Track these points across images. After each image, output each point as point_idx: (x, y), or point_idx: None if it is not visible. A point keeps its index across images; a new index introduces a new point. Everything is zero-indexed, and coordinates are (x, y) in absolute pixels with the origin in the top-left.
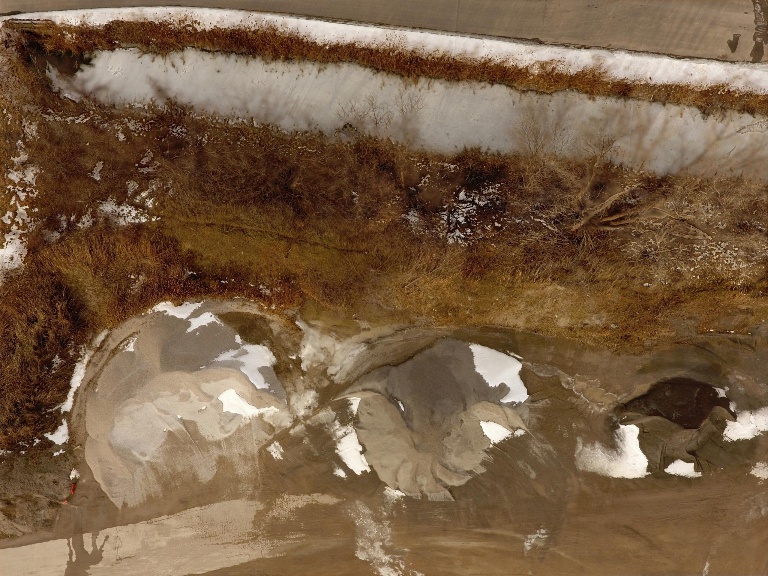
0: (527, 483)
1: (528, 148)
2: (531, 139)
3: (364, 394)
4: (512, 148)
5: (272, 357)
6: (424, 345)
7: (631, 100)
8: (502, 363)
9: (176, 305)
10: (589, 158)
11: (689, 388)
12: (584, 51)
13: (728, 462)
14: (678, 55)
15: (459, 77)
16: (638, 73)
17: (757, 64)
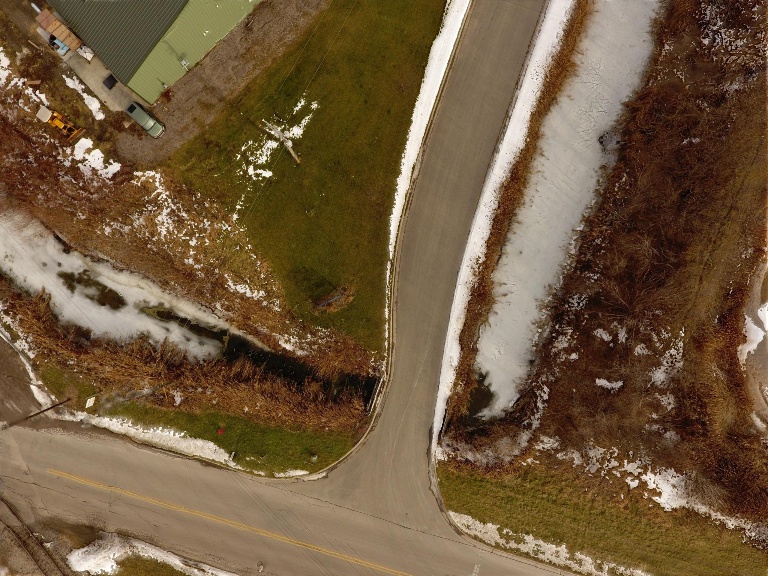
0: None
1: None
2: None
3: None
4: None
5: None
6: None
7: None
8: None
9: (745, 341)
10: None
11: None
12: None
13: None
14: None
15: (579, 22)
16: None
17: None
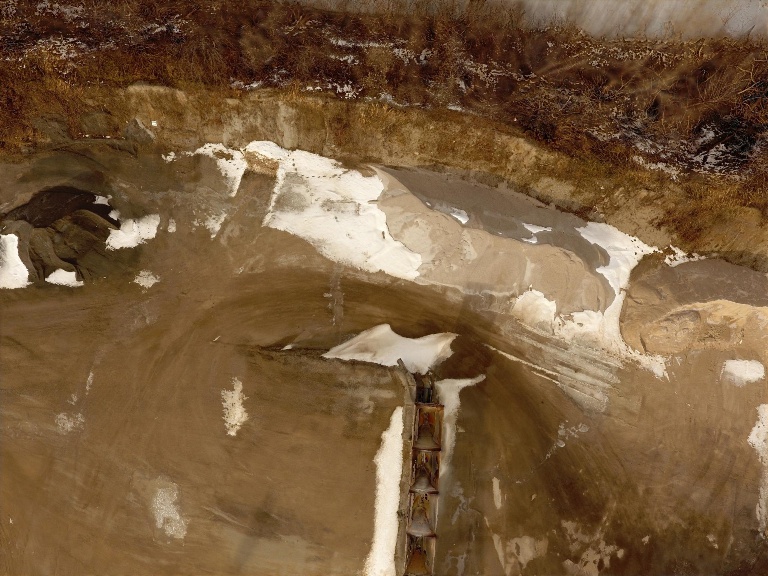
0: None
1: None
2: None
3: None
4: None
5: None
6: None
7: None
8: None
9: None
10: None
11: (66, 195)
12: None
13: (110, 271)
14: None
15: None
16: None
17: None
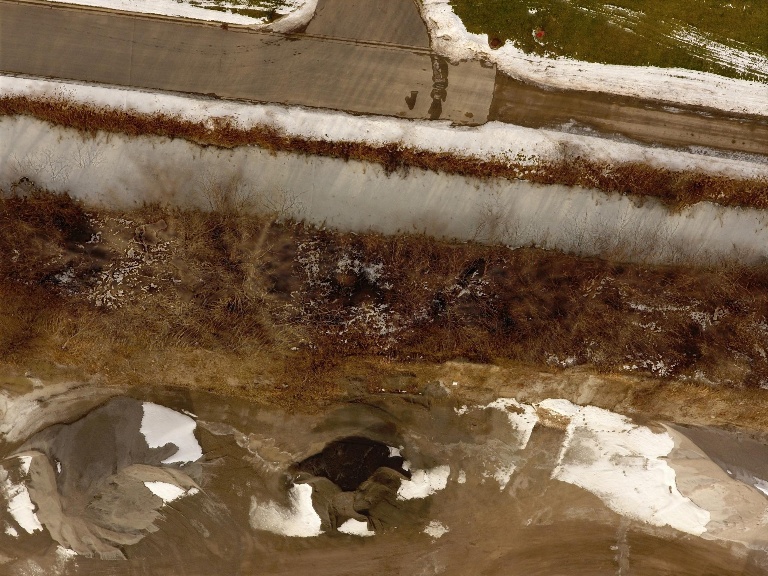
0: (200, 542)
1: (208, 204)
2: (212, 195)
3: (33, 453)
4: (192, 204)
5: None
6: (98, 403)
7: (313, 156)
8: (171, 423)
9: None
10: (271, 214)
11: (361, 447)
12: (258, 107)
13: (401, 521)
14: (356, 111)
15: (137, 131)
16: (313, 130)
17: (434, 122)
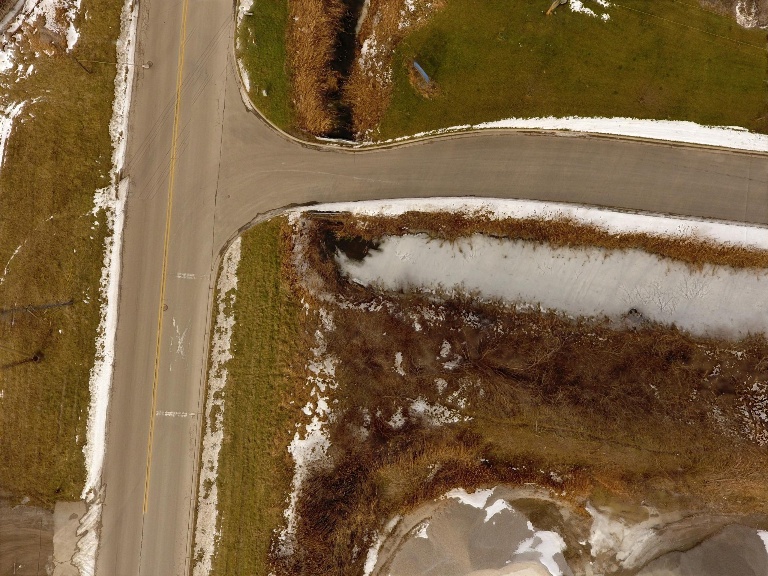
0: None
1: None
2: None
3: None
4: None
5: (562, 543)
6: (711, 531)
7: None
8: None
9: (469, 492)
10: None
11: None
12: None
13: None
14: None
15: (744, 264)
16: None
17: None
